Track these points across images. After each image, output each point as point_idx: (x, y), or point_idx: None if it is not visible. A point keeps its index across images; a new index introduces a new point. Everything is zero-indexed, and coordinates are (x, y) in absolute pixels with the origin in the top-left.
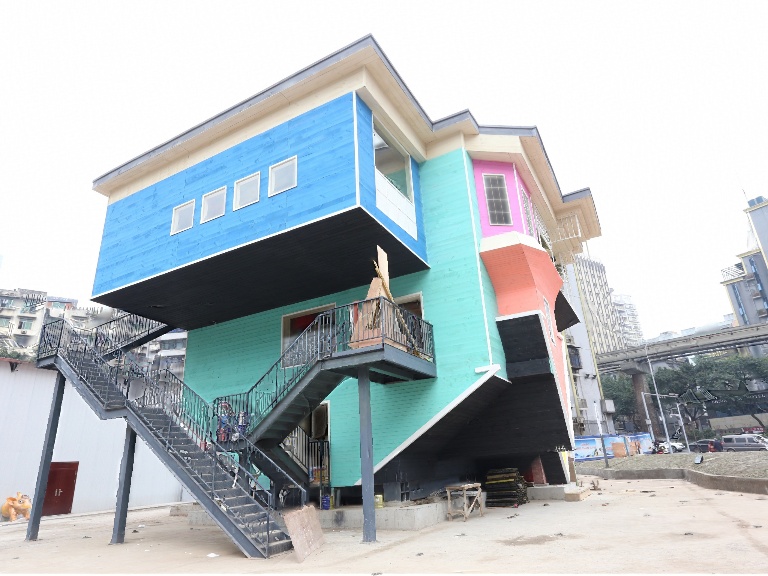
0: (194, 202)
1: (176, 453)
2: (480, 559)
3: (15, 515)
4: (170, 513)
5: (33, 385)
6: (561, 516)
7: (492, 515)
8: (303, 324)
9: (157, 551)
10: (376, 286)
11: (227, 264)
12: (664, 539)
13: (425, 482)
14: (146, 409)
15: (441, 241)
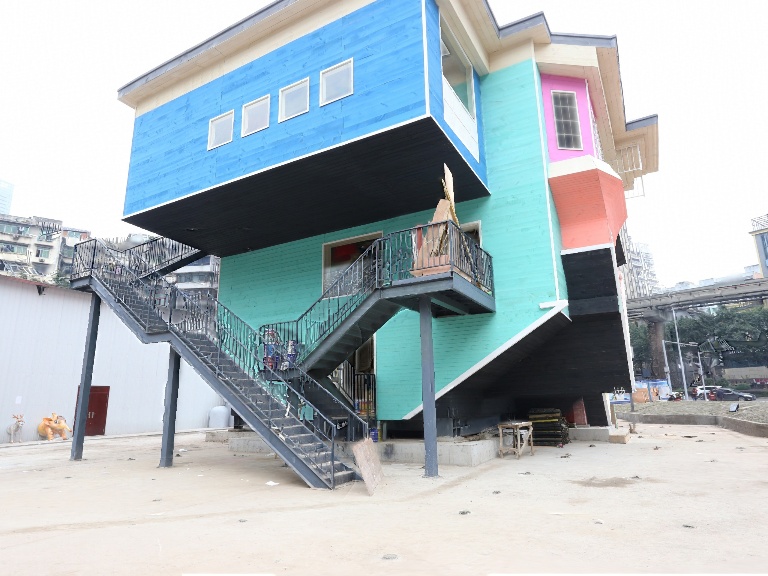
0: (233, 113)
1: (226, 380)
2: (569, 501)
3: (52, 434)
4: (205, 439)
5: (61, 309)
6: (618, 458)
7: (542, 454)
8: (344, 254)
9: (211, 477)
10: (443, 209)
11: (271, 183)
12: (759, 487)
13: (472, 419)
14: (189, 334)
15: (504, 165)
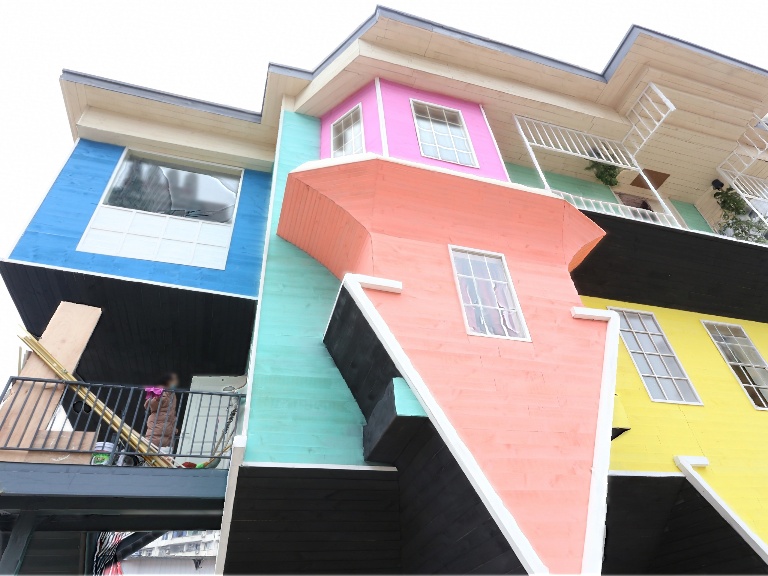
0: None
1: None
2: None
3: None
4: None
5: None
6: None
7: None
8: None
9: None
10: None
11: None
12: None
13: None
14: None
15: None
